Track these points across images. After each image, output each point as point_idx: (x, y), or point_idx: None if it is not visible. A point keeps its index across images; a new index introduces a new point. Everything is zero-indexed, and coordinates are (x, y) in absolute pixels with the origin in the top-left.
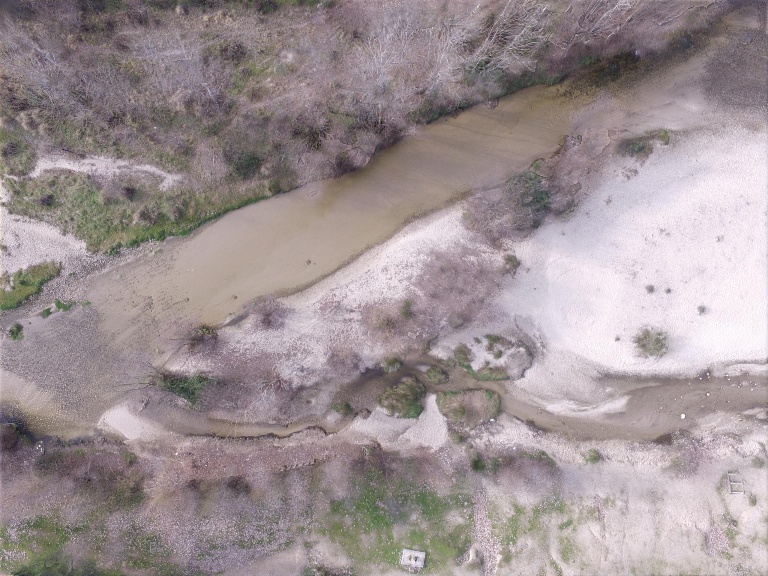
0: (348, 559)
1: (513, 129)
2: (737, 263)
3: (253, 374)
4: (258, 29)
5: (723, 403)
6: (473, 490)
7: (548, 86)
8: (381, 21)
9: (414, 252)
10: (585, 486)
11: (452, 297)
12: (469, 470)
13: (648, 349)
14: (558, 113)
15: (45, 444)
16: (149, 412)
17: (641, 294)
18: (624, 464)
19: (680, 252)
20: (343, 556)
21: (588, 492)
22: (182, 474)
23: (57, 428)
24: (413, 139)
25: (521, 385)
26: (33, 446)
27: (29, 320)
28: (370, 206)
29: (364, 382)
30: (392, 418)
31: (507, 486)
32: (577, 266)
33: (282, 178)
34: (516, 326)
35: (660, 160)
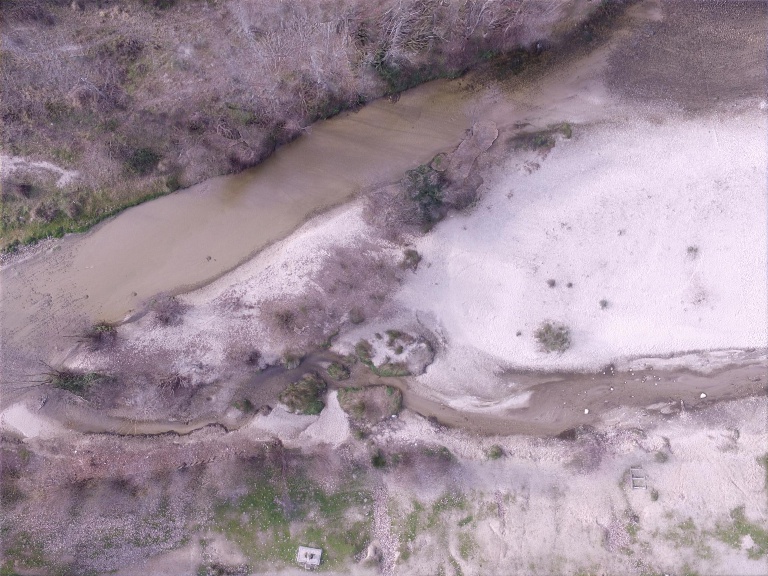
0: (244, 557)
1: (415, 123)
2: (639, 257)
3: (151, 371)
4: (155, 24)
5: (627, 398)
6: (373, 487)
7: (450, 80)
8: (279, 16)
9: (314, 248)
10: (486, 482)
11: (352, 293)
12: (370, 467)
13: (550, 344)
14: (460, 107)
15: None
16: (48, 410)
17: (542, 288)
18: (526, 460)
19: (581, 246)
20: (239, 554)
21: (489, 488)
22: (80, 472)
23: None
24: (314, 134)
25: (423, 381)
26: None
27: None
28: (271, 202)
29: (265, 379)
30: (293, 415)
31: (407, 482)
32: (478, 261)
33: (180, 174)
34: (418, 321)
35: (562, 154)
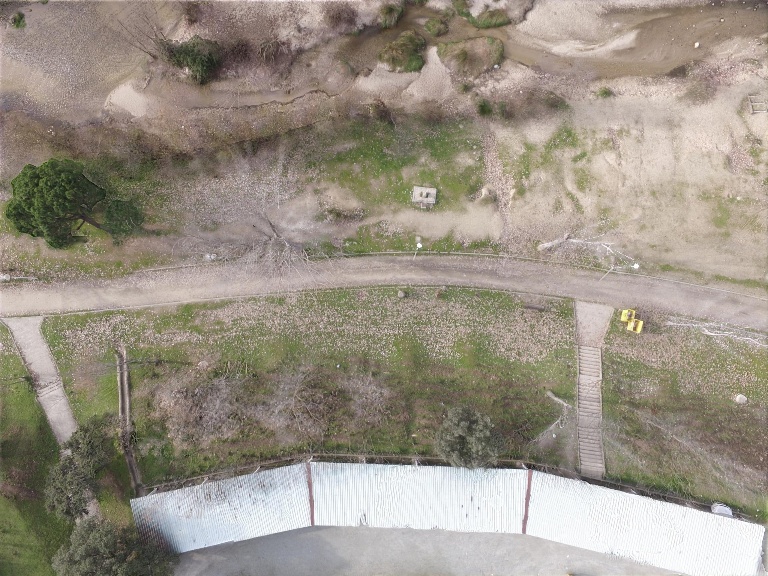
0: (359, 202)
1: None
2: None
3: (251, 38)
4: None
5: (739, 28)
6: (481, 135)
7: None
8: None
9: None
10: (597, 120)
11: None
12: (476, 117)
13: None
14: None
15: (56, 129)
16: (153, 88)
17: None
18: (637, 96)
19: None
20: (354, 199)
21: (601, 125)
22: (189, 144)
23: (66, 113)
24: None
25: (523, 28)
26: (44, 130)
27: (30, 7)
28: None
29: (363, 40)
30: (394, 73)
31: (516, 126)
32: None
33: None
34: None
35: None
